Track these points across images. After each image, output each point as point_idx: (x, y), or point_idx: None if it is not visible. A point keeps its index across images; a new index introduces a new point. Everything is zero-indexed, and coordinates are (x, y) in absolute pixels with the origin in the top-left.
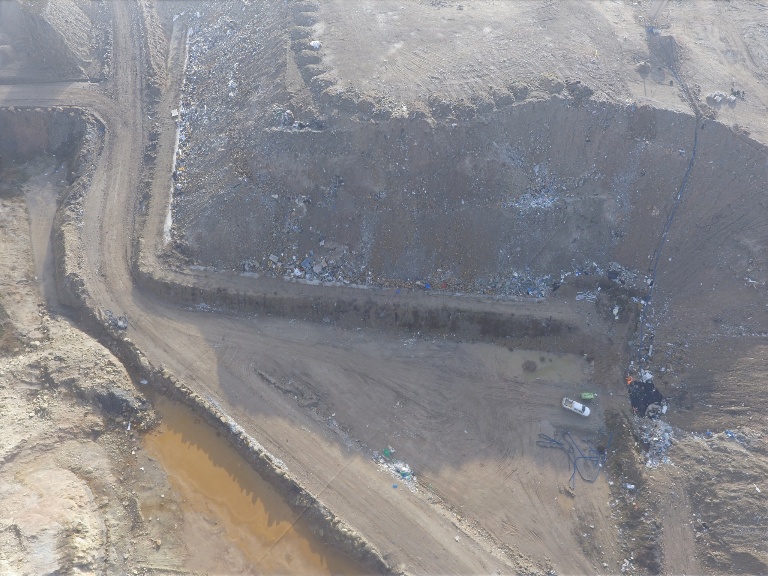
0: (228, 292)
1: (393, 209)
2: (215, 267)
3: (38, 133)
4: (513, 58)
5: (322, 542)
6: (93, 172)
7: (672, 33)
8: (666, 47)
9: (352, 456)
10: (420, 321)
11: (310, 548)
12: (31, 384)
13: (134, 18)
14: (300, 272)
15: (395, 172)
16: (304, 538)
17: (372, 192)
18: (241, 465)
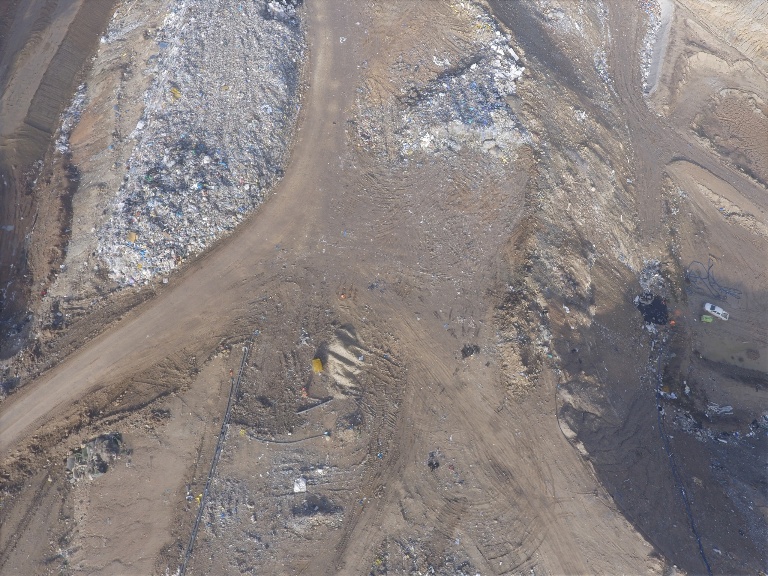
0: None
1: None
2: None
3: None
4: None
5: None
6: None
7: None
8: None
9: None
10: None
11: None
12: None
13: None
14: None
15: None
16: None
17: None
18: None
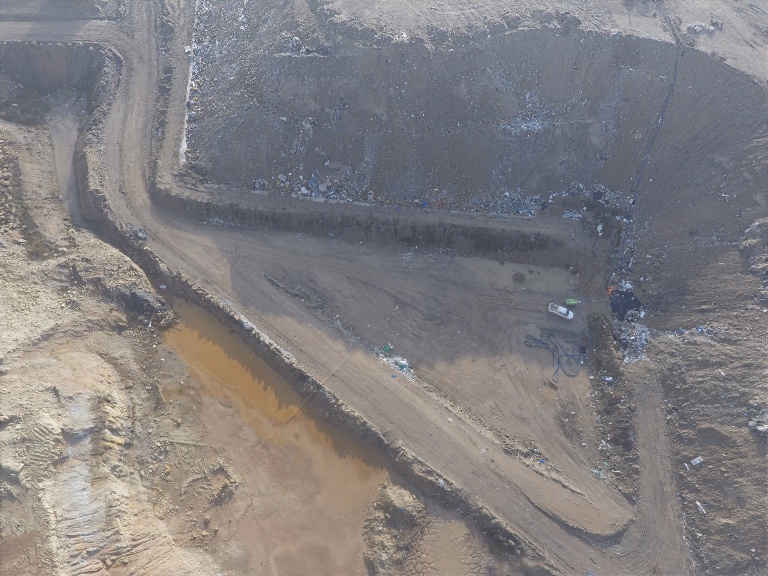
0: (240, 207)
1: (393, 131)
2: (227, 185)
3: (59, 67)
4: None
5: (327, 423)
6: (112, 101)
7: None
8: None
9: (355, 350)
10: (418, 236)
11: (316, 428)
12: (61, 281)
13: None
14: (307, 190)
15: (395, 95)
16: (311, 420)
17: (374, 115)
18: (253, 358)
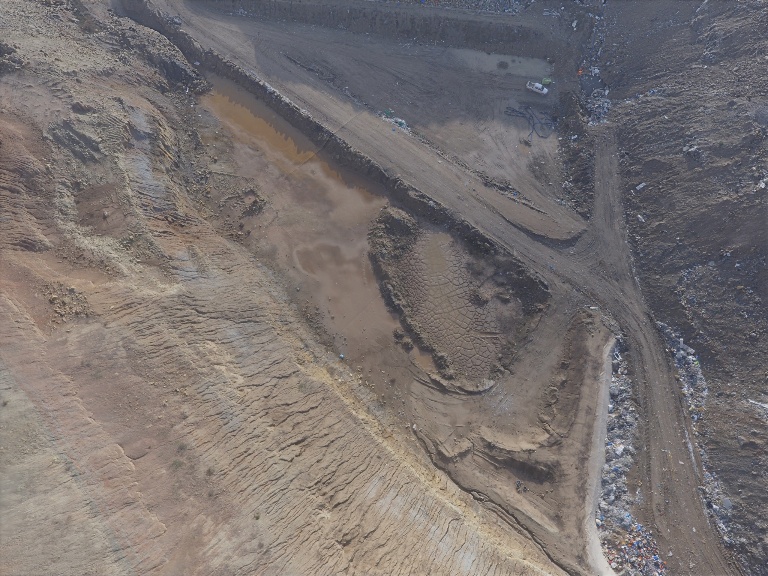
0: None
1: None
2: None
3: None
4: None
5: (338, 164)
6: None
7: None
8: None
9: (361, 110)
10: (416, 28)
11: (329, 167)
12: (113, 45)
13: None
14: None
15: None
16: (324, 161)
17: None
18: (275, 117)
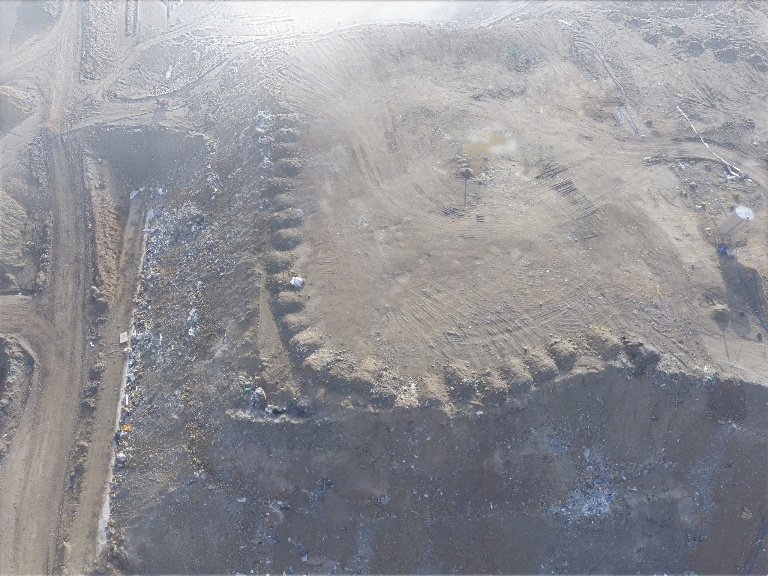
0: None
1: (399, 516)
2: None
3: None
4: (552, 300)
5: None
6: (14, 431)
7: (750, 254)
8: (748, 283)
9: None
10: None
11: None
12: None
13: (80, 205)
14: None
15: (401, 471)
16: None
17: (371, 495)
18: None
